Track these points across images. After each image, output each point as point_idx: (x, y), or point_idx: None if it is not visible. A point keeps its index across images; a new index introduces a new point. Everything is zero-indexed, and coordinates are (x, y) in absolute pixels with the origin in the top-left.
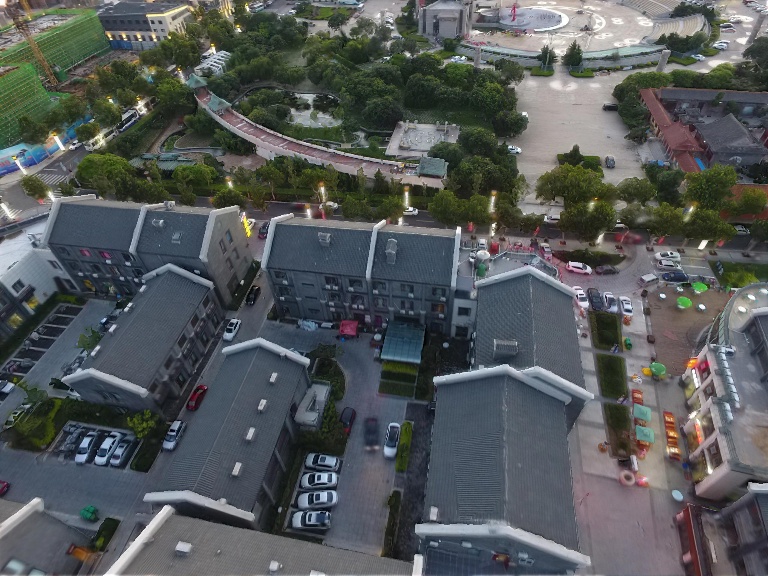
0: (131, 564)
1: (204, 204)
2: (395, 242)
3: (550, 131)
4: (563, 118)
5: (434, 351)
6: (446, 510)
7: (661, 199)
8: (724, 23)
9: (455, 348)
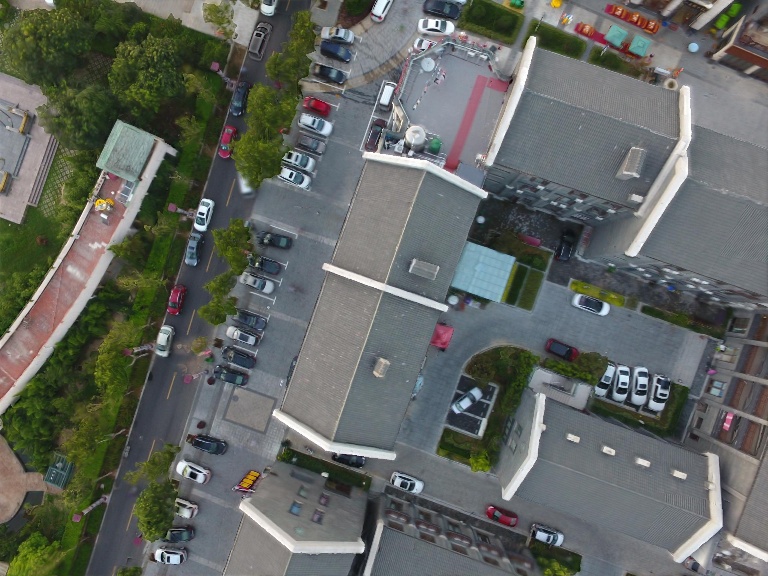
0: None
1: (114, 548)
2: (417, 262)
3: None
4: None
5: (512, 238)
6: None
7: None
8: None
9: (483, 210)
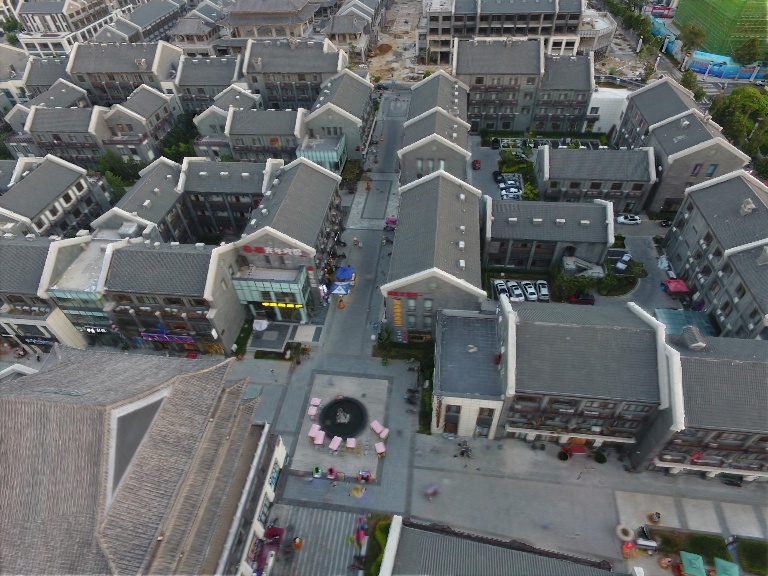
0: (450, 181)
1: None
2: None
3: None
4: None
5: None
6: (520, 306)
7: None
8: None
9: None
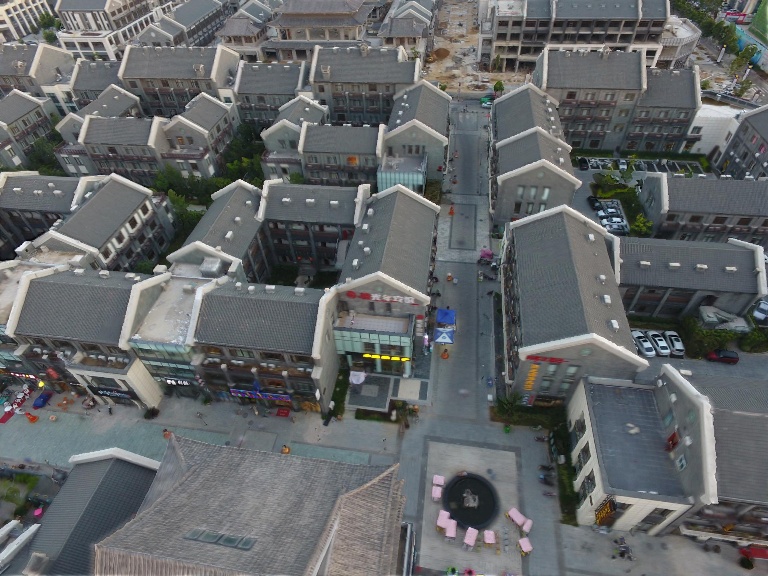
0: (574, 218)
1: None
2: None
3: None
4: None
5: None
6: (694, 382)
7: None
8: None
9: None
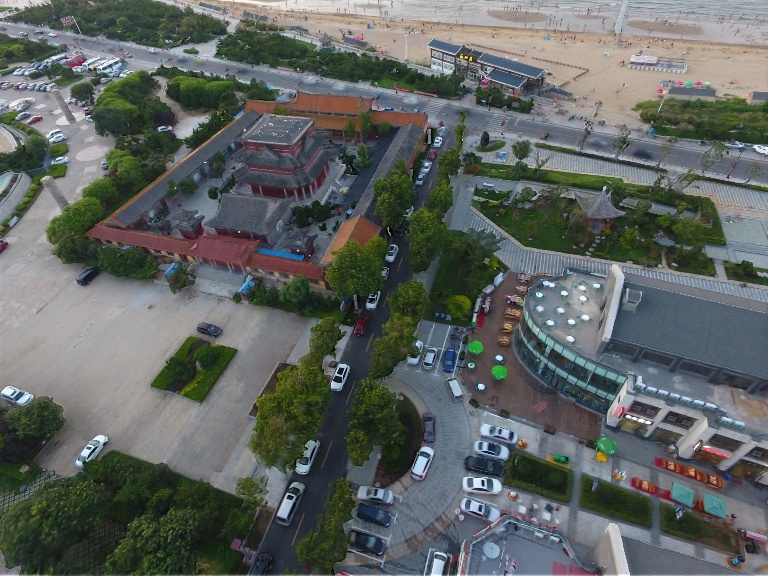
0: None
1: None
2: None
3: (81, 371)
4: (61, 340)
5: None
6: None
7: (314, 313)
8: (17, 115)
9: None
